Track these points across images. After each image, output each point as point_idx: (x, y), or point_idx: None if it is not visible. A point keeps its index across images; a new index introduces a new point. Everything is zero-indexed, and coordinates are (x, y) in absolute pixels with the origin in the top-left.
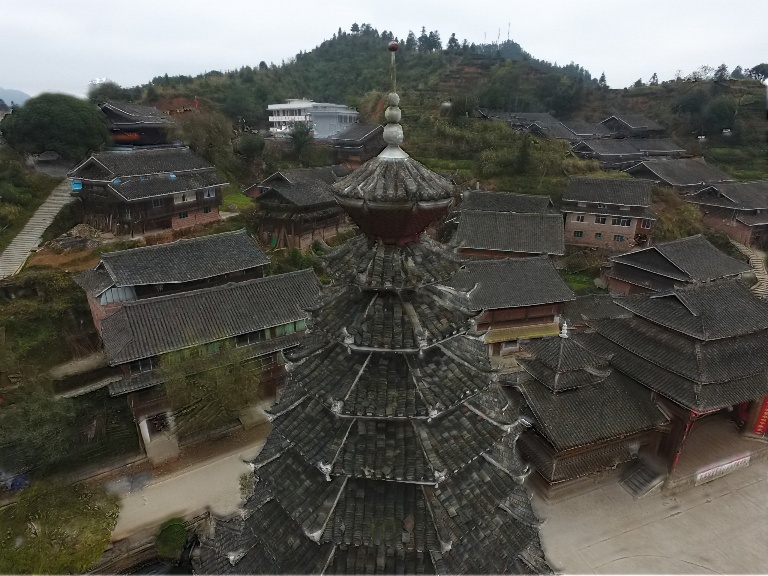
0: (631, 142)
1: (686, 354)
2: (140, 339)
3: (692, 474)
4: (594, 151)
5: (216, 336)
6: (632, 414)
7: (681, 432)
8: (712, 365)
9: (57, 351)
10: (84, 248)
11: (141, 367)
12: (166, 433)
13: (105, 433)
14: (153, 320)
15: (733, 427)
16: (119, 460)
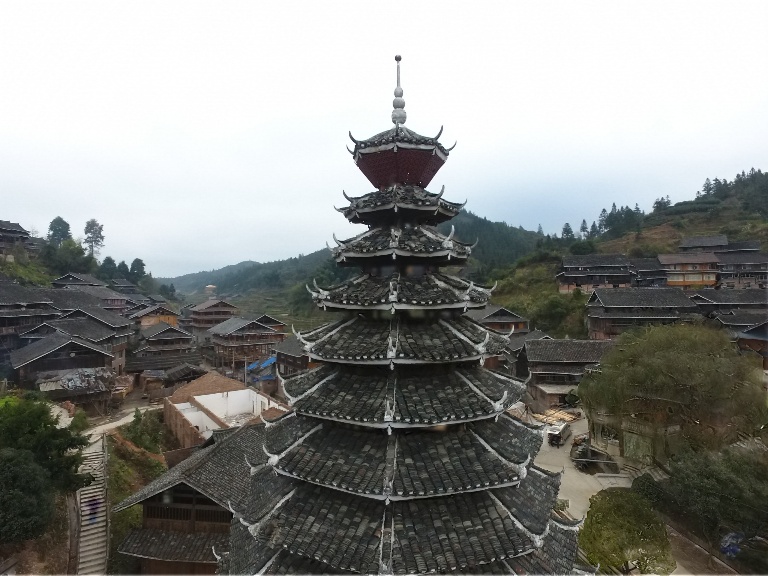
0: None
1: None
2: None
3: None
4: None
5: None
6: None
7: None
8: None
9: None
10: None
11: None
12: None
13: None
14: None
15: None
16: None
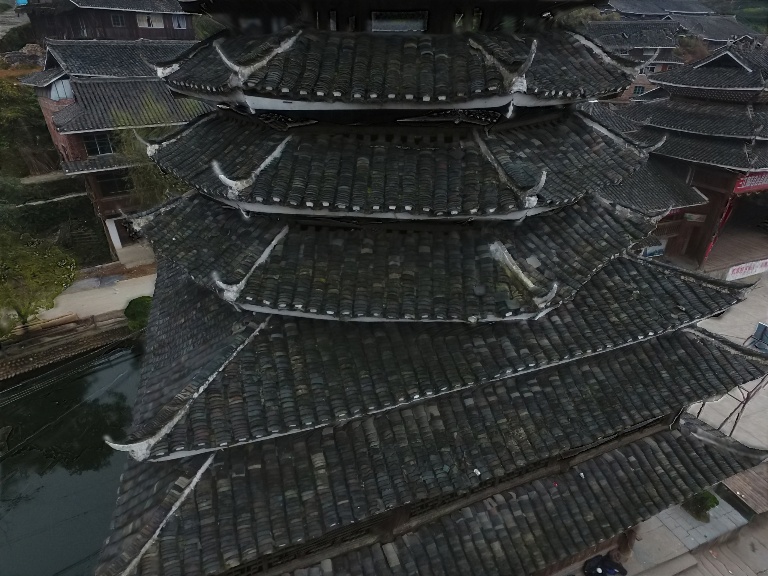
0: (655, 2)
1: (736, 117)
2: (94, 113)
3: (724, 266)
4: (614, 8)
5: (185, 119)
6: (665, 193)
7: (720, 210)
8: (767, 125)
9: (10, 162)
10: (35, 66)
11: (99, 148)
12: (140, 241)
13: (69, 236)
14: (109, 98)
15: (767, 234)
16: (88, 265)
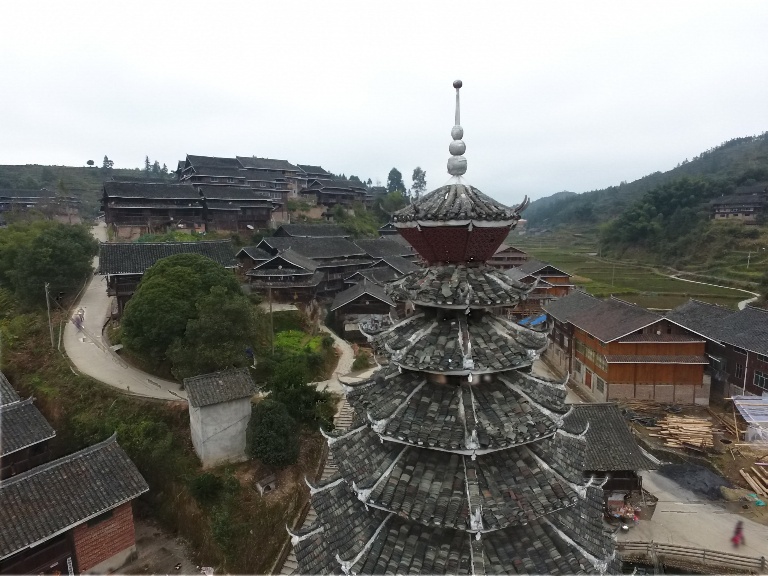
0: None
1: None
2: None
3: None
4: None
5: None
6: None
7: None
8: None
9: None
10: None
11: None
12: None
13: None
14: None
15: None
16: None
